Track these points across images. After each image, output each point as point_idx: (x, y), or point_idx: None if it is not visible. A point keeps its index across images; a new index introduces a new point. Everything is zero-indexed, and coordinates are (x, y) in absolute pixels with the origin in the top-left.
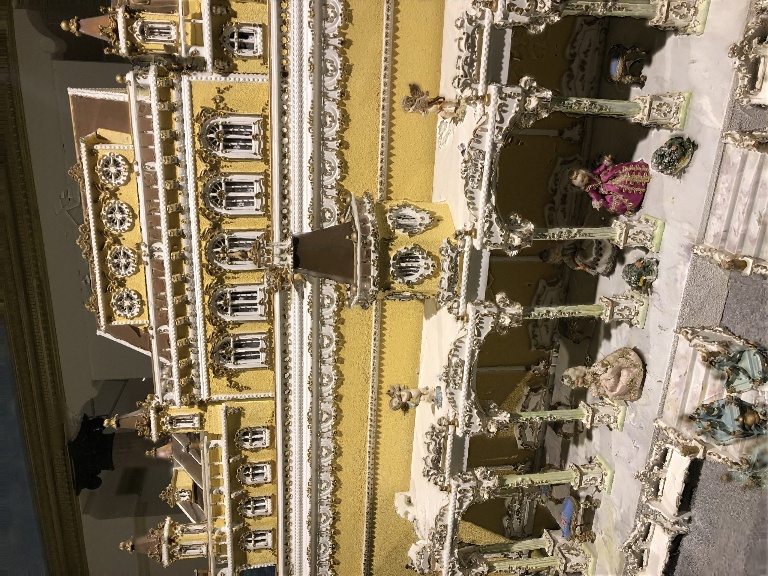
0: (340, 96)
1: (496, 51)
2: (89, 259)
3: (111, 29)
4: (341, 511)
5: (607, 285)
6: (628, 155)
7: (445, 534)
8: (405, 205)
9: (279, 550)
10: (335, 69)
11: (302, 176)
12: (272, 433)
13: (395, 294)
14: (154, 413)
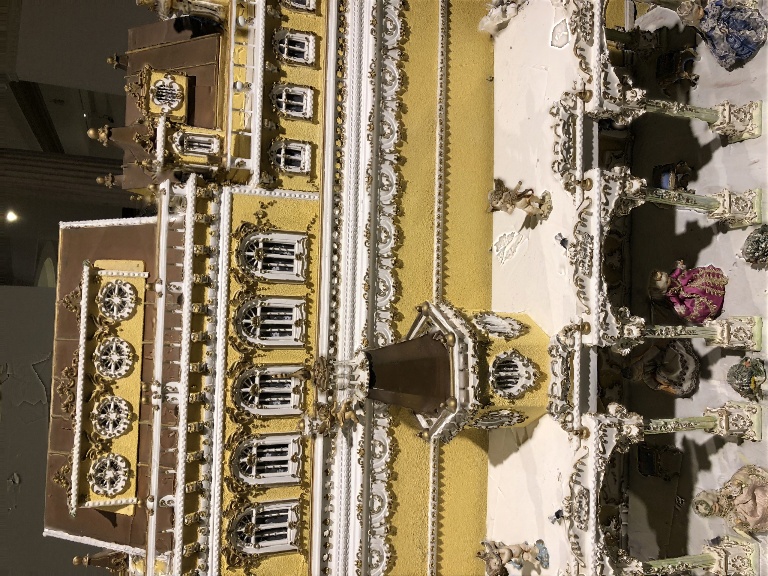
0: (396, 211)
1: (587, 141)
2: (70, 413)
3: (148, 137)
4: None
5: (690, 407)
6: (689, 266)
7: None
8: (488, 313)
9: None
10: (391, 184)
11: (354, 296)
12: None
13: (490, 414)
14: None
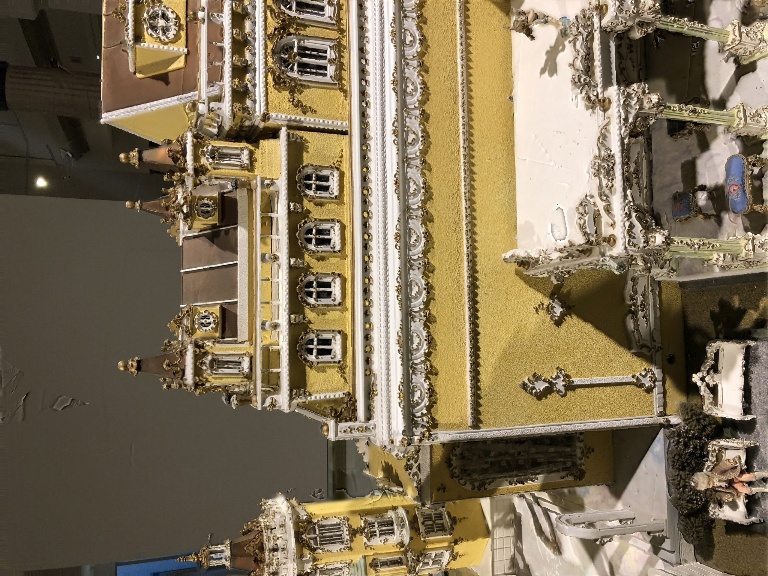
0: None
1: None
2: None
3: None
4: (435, 286)
5: None
6: None
7: (612, 165)
8: None
9: (356, 346)
10: None
11: None
12: (341, 180)
13: None
14: (192, 137)
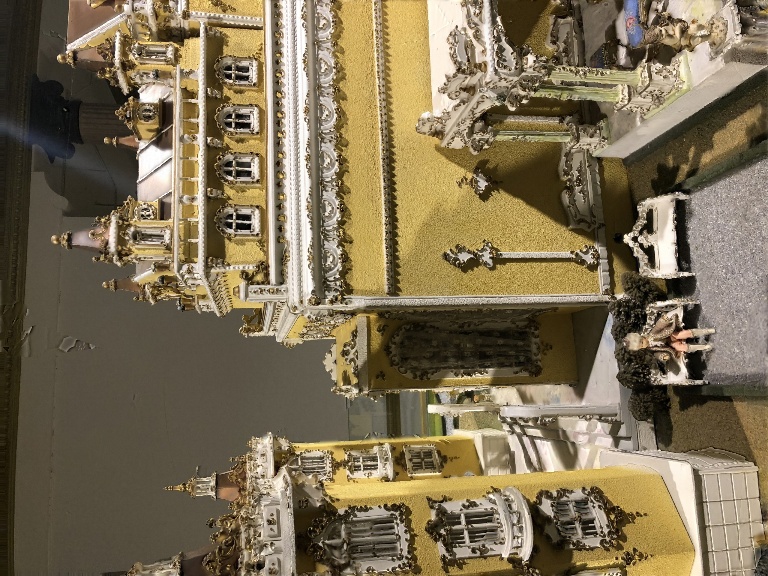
0: None
1: None
2: None
3: None
4: (349, 159)
5: None
6: None
7: None
8: None
9: (269, 214)
10: None
11: None
12: (260, 70)
13: None
14: (120, 37)
